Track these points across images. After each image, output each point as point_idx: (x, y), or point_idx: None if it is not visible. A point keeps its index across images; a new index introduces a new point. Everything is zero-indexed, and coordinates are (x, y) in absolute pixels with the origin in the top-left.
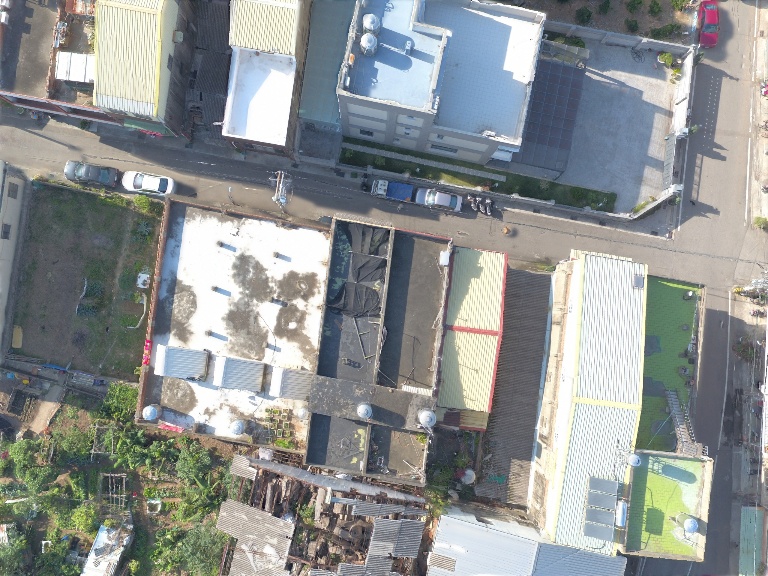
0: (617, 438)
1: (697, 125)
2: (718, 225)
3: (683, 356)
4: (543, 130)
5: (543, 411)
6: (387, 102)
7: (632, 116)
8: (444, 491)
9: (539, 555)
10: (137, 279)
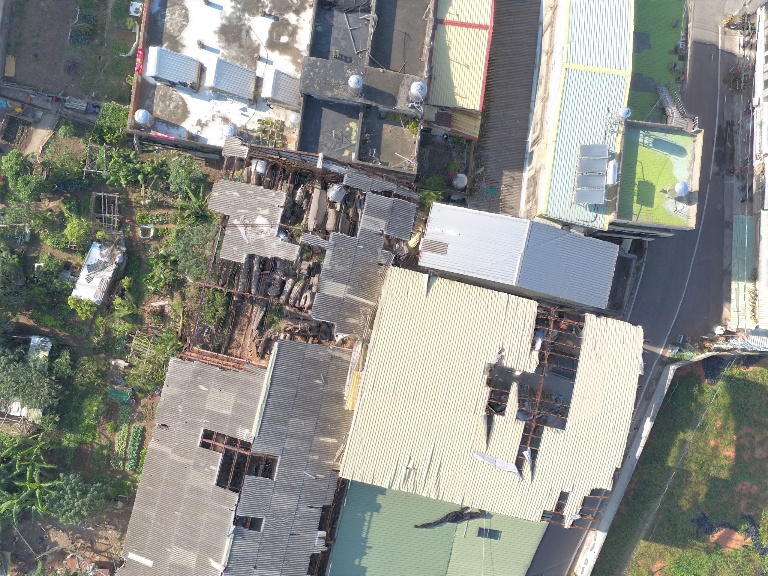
0: (607, 105)
1: None
2: None
3: (673, 53)
4: None
5: (534, 119)
6: None
7: None
8: None
9: (531, 233)
10: (129, 7)
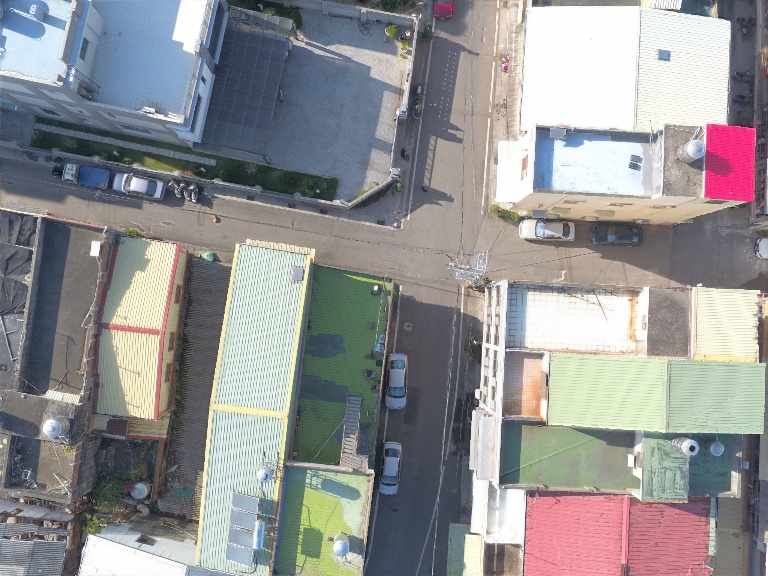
0: (263, 450)
1: (431, 104)
2: (451, 213)
3: (370, 357)
4: (239, 108)
5: None
6: (6, 73)
7: (358, 94)
8: (135, 506)
9: None
10: None
